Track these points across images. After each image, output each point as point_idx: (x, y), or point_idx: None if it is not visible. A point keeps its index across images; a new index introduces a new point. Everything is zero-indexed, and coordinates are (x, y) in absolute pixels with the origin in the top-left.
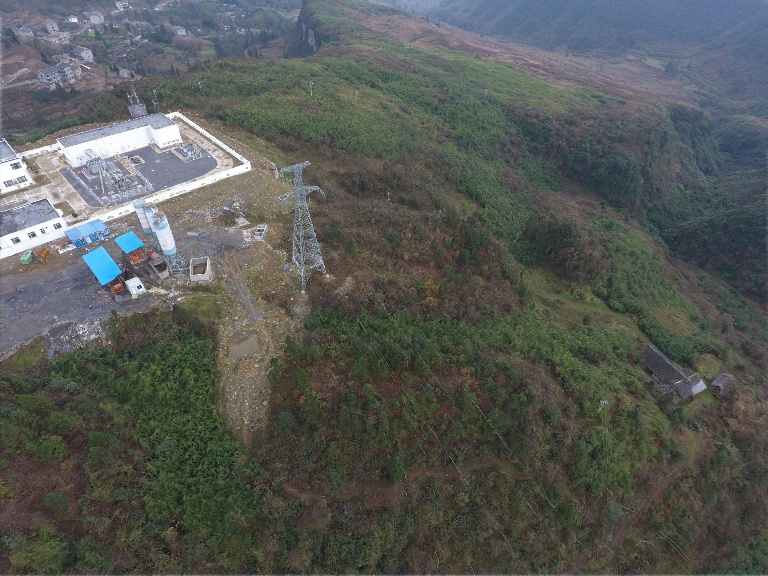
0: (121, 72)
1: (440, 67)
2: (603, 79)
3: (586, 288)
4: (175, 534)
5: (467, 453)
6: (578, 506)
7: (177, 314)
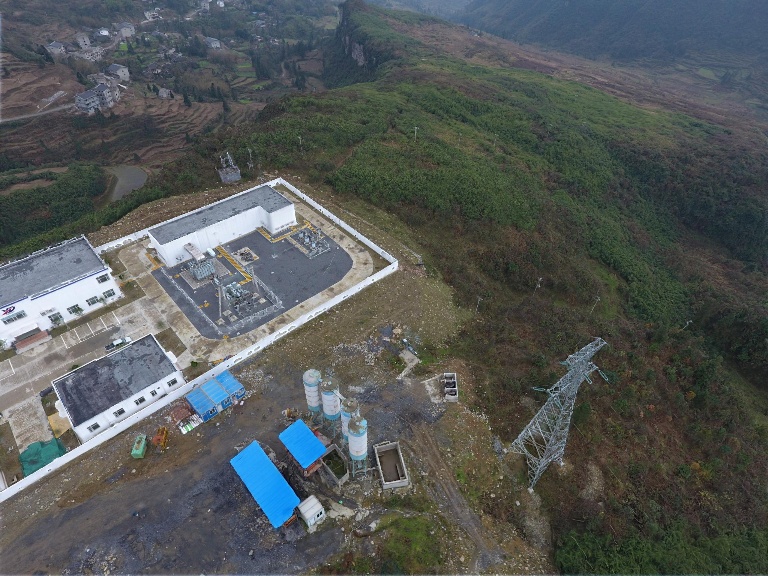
0: (160, 92)
1: (522, 92)
2: (679, 98)
3: None
4: None
5: None
6: None
7: (391, 575)
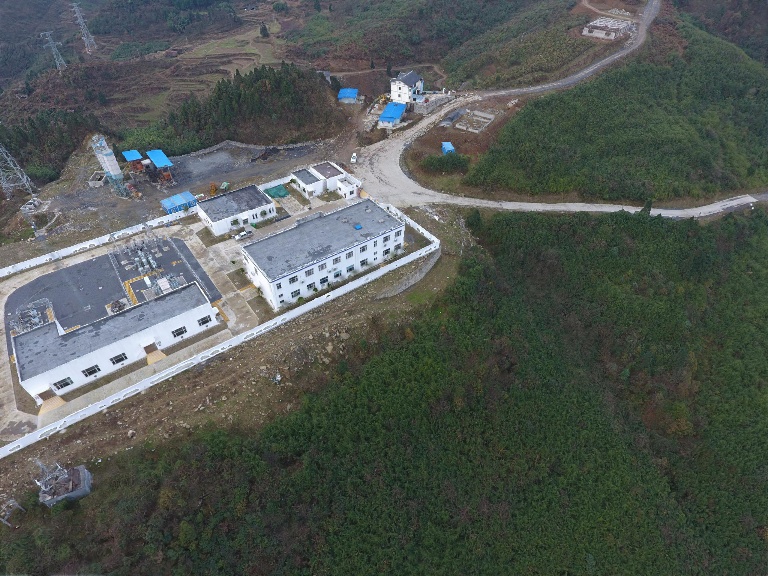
0: None
1: None
2: None
3: None
4: None
5: None
6: None
7: None
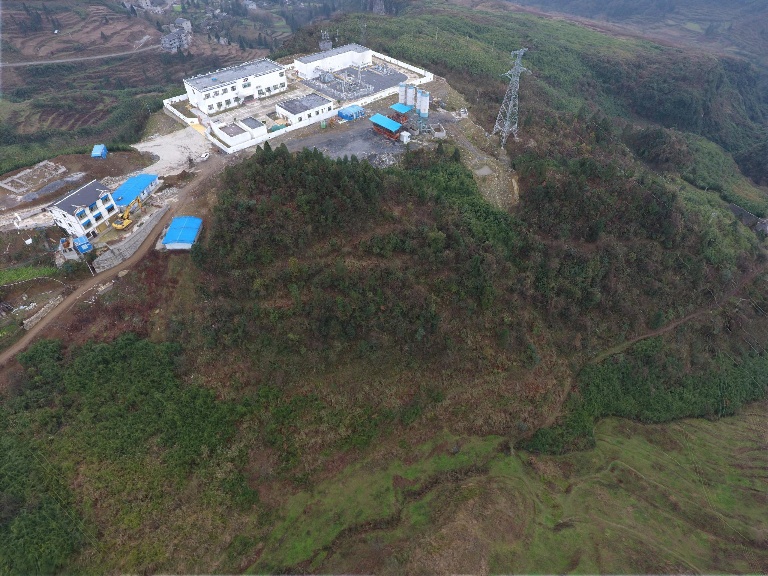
0: None
1: (516, 23)
2: None
3: (676, 174)
4: None
5: (635, 229)
6: (705, 264)
7: (441, 150)
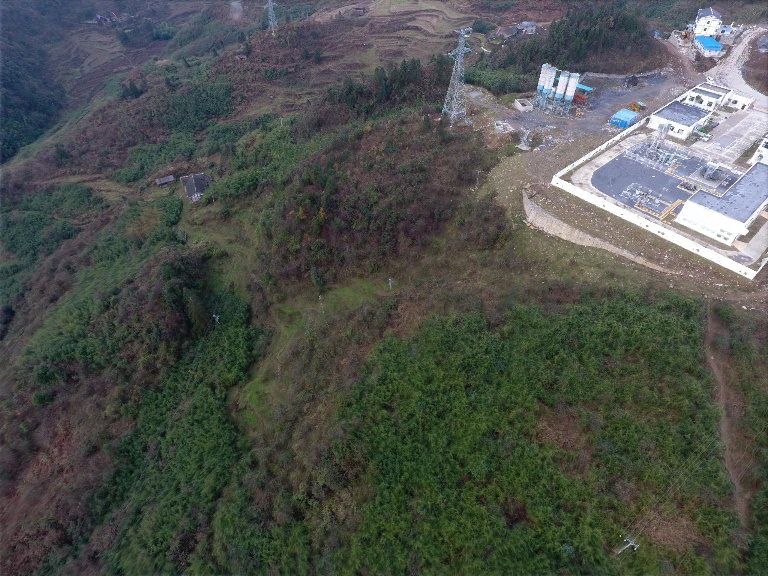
0: None
1: None
2: None
3: None
4: (472, 62)
5: None
6: None
7: None
